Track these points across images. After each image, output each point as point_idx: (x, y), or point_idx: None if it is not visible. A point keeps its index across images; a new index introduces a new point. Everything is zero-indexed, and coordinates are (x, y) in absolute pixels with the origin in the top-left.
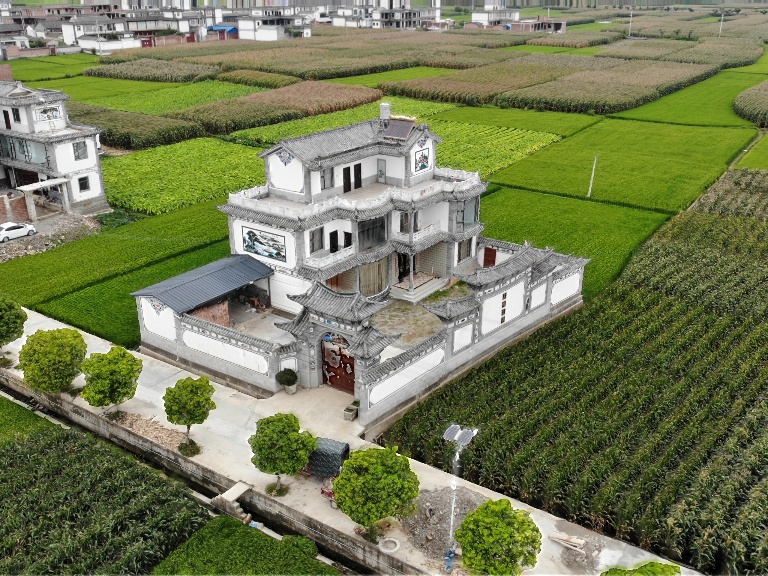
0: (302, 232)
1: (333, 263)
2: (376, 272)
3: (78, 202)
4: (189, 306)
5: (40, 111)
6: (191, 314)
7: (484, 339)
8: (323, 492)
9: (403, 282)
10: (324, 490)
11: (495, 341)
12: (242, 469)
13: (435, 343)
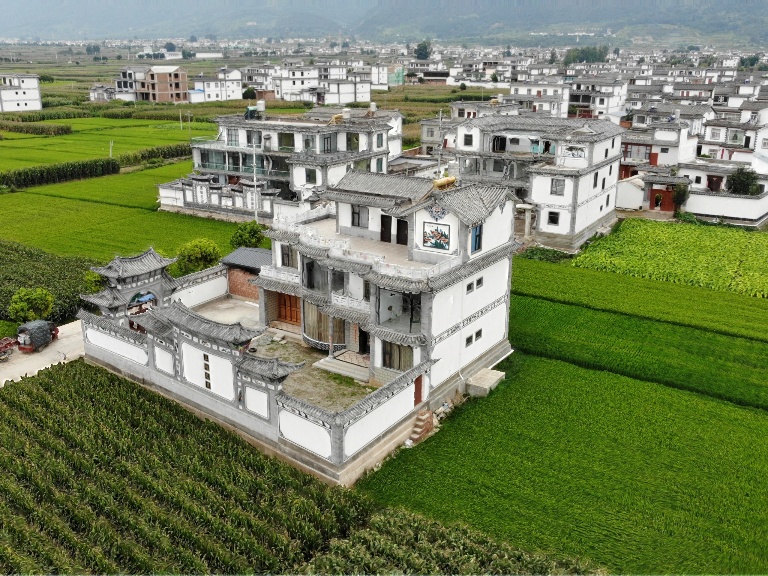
0: (273, 240)
1: (275, 279)
2: (315, 316)
3: (544, 232)
4: (228, 261)
5: (566, 148)
6: (235, 269)
7: (188, 385)
8: (7, 340)
9: (359, 354)
10: (5, 338)
11: (202, 401)
12: (70, 327)
13: (130, 336)
